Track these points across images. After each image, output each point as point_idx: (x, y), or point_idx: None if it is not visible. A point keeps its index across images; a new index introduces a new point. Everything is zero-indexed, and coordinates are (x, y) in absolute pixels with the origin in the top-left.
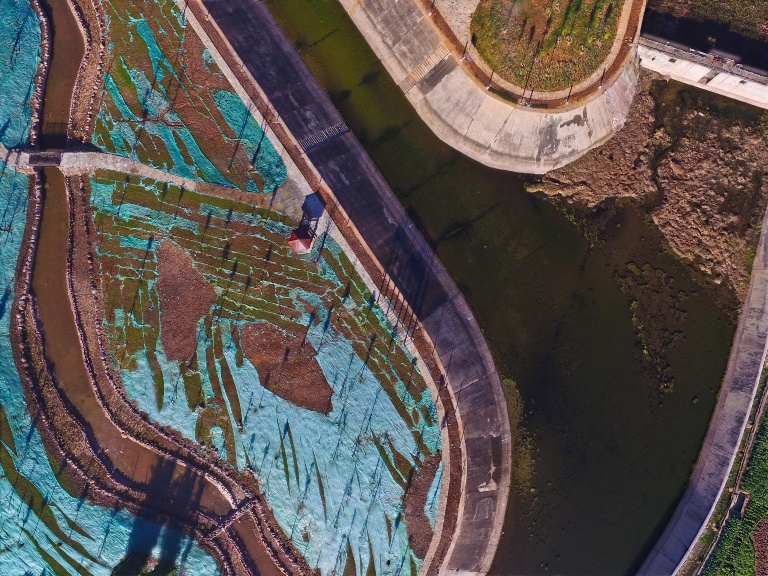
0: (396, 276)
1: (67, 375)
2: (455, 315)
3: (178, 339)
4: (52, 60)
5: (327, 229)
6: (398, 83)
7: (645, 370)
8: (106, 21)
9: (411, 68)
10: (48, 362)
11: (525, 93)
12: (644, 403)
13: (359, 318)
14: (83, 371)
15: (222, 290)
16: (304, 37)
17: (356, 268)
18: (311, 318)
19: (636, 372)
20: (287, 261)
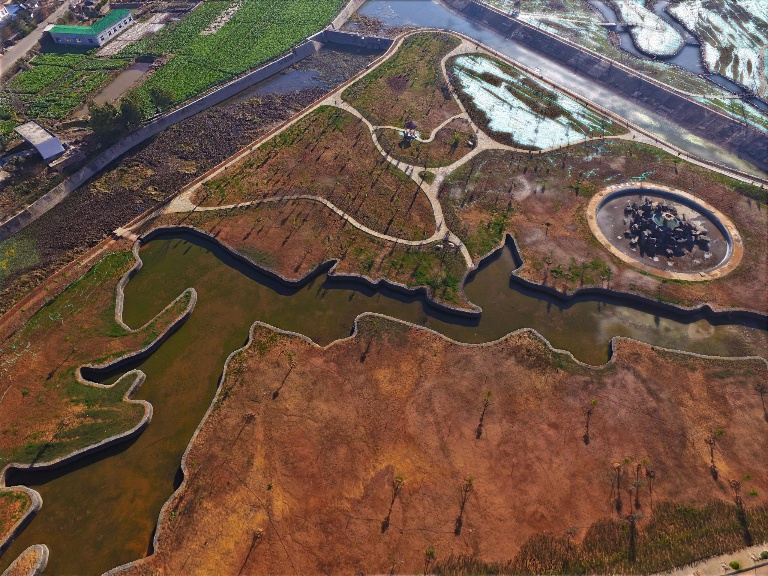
0: None
1: None
2: None
3: (556, 1)
4: None
5: None
6: None
7: None
8: None
9: None
10: (600, 1)
11: None
12: (390, 1)
13: None
14: (587, 0)
15: (543, 6)
16: None
17: None
18: (510, 2)
19: None
20: (522, 9)
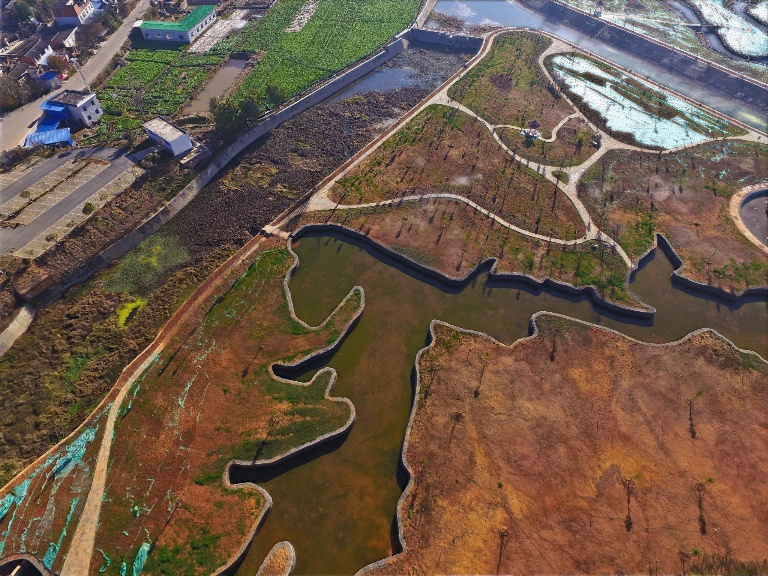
0: (561, 7)
1: (668, 0)
2: None
3: None
4: None
5: None
6: None
7: (464, 3)
8: None
9: None
10: None
11: None
12: None
13: (571, 1)
14: None
15: (623, 6)
16: None
17: (576, 7)
18: None
19: (467, 3)
20: None
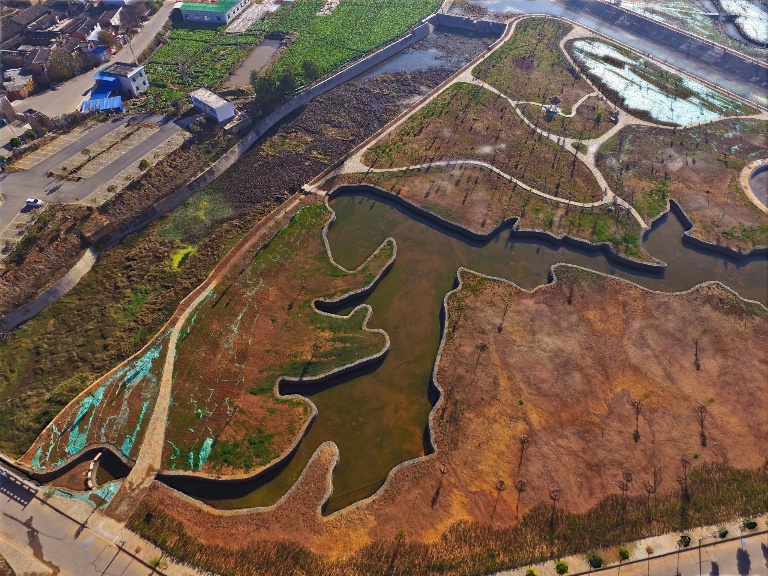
0: None
1: None
2: None
3: None
4: None
5: (611, 1)
6: None
7: None
8: None
9: None
10: None
11: None
12: None
13: None
14: None
15: None
16: None
17: None
18: None
19: None
20: None
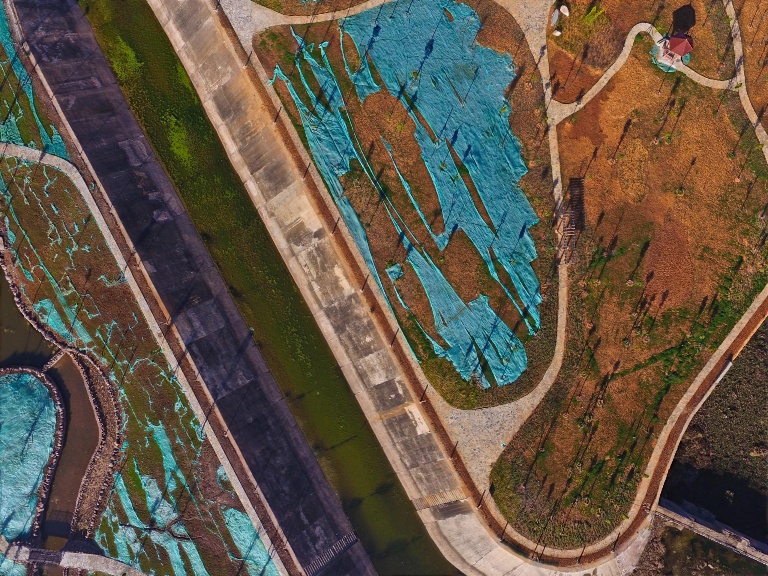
0: None
1: None
2: None
3: None
4: (64, 447)
5: None
6: (411, 499)
7: None
8: (123, 419)
9: (426, 493)
10: None
11: (537, 548)
12: None
13: None
14: None
15: None
16: (322, 440)
17: None
18: None
19: None
20: None
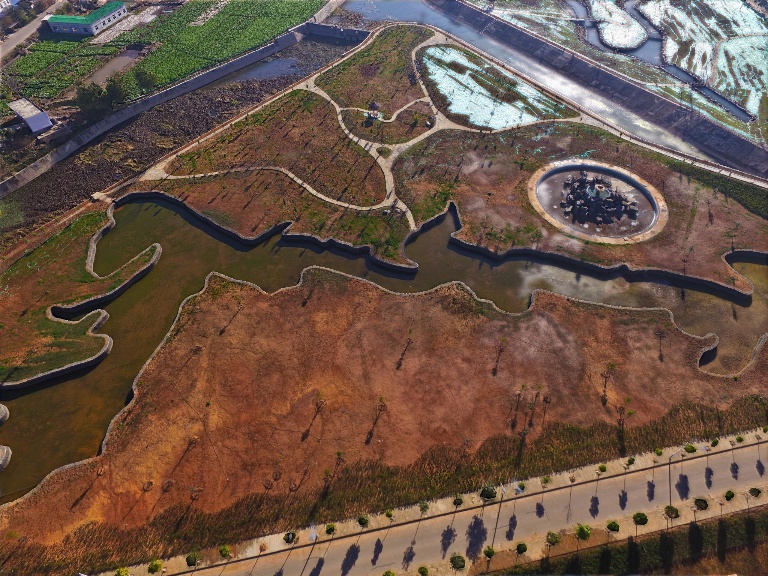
0: (458, 4)
1: None
2: (437, 4)
3: None
4: None
5: (483, 8)
6: None
7: None
8: None
9: None
10: None
11: None
12: None
13: None
14: None
15: None
16: None
17: None
18: None
19: None
20: None
